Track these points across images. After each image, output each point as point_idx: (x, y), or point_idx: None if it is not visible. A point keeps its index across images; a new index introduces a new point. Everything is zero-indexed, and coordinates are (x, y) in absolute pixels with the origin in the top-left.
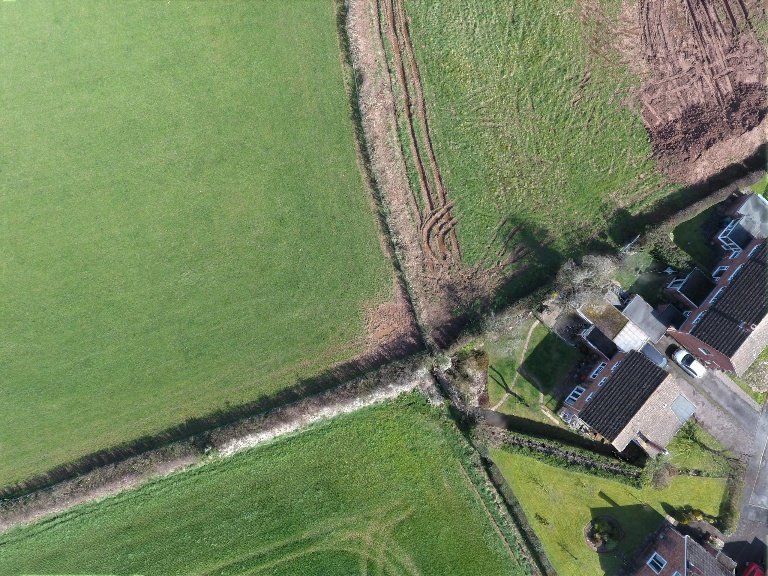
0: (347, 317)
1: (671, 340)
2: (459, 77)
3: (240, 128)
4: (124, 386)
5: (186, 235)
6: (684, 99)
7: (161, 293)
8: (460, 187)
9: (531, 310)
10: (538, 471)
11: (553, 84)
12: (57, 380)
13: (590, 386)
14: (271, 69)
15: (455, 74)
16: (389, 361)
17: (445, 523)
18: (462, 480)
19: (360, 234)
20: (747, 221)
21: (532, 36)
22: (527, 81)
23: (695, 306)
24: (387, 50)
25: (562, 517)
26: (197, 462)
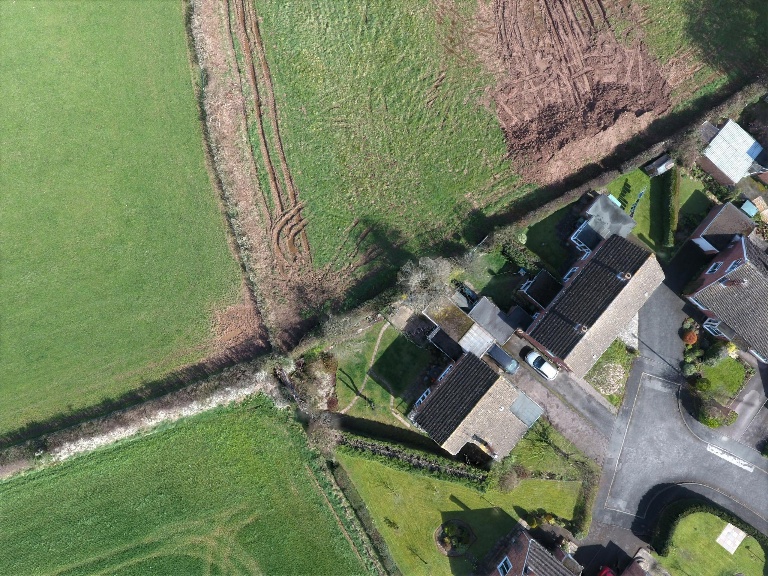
0: (193, 319)
1: (525, 342)
2: (311, 77)
3: (86, 129)
4: None
5: (29, 237)
6: (540, 99)
7: (3, 295)
8: (311, 188)
9: (379, 312)
10: (388, 474)
11: (407, 84)
12: None
13: (434, 389)
14: (118, 69)
15: (306, 74)
16: None
17: (292, 527)
18: (309, 484)
19: (207, 236)
20: (596, 222)
21: (385, 35)
22: (380, 81)
23: (542, 308)
24: (237, 50)
25: (412, 521)
26: (35, 466)
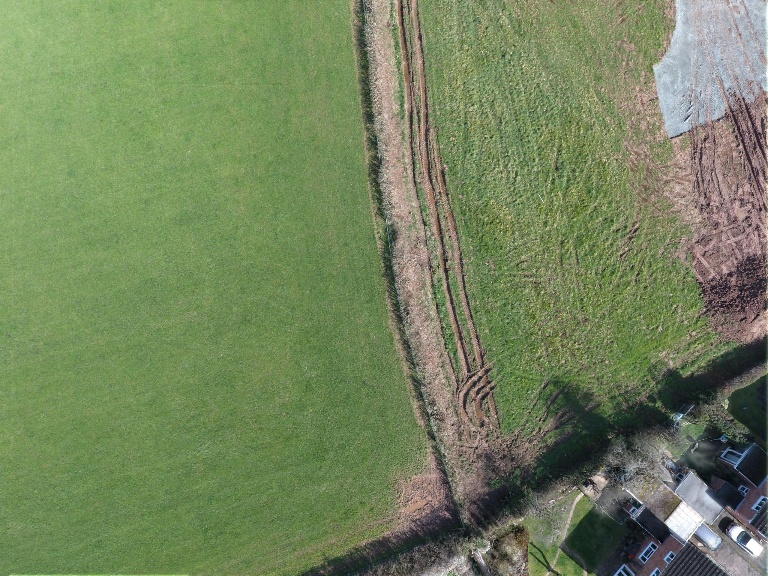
0: (378, 491)
1: (725, 513)
2: (499, 229)
3: (264, 286)
4: (139, 569)
5: (206, 403)
6: (739, 251)
7: (179, 467)
8: (499, 347)
9: (575, 485)
10: None
11: (599, 236)
12: (67, 564)
13: (640, 573)
14: (298, 222)
15: (494, 226)
16: (422, 538)
17: None
18: None
19: (392, 400)
20: None
21: (577, 184)
22: (571, 233)
23: (753, 484)
24: (422, 201)
25: None
26: None
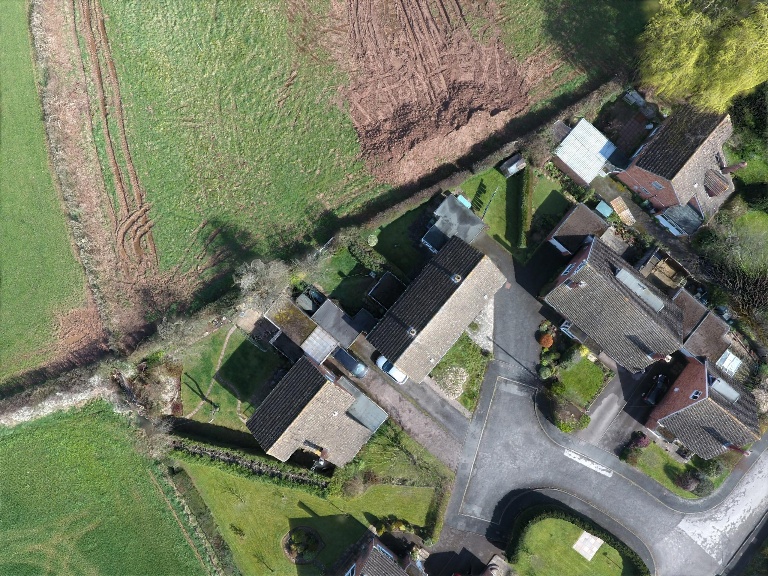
0: (34, 323)
1: None
2: (158, 76)
3: None
4: None
5: None
6: (395, 98)
7: None
8: (158, 189)
9: (223, 315)
10: (234, 481)
11: (257, 83)
12: None
13: None
14: None
15: (153, 73)
16: None
17: (133, 535)
18: (152, 490)
19: (49, 238)
20: (443, 223)
21: (235, 34)
22: (230, 80)
23: (387, 310)
24: (82, 48)
25: (259, 528)
26: None
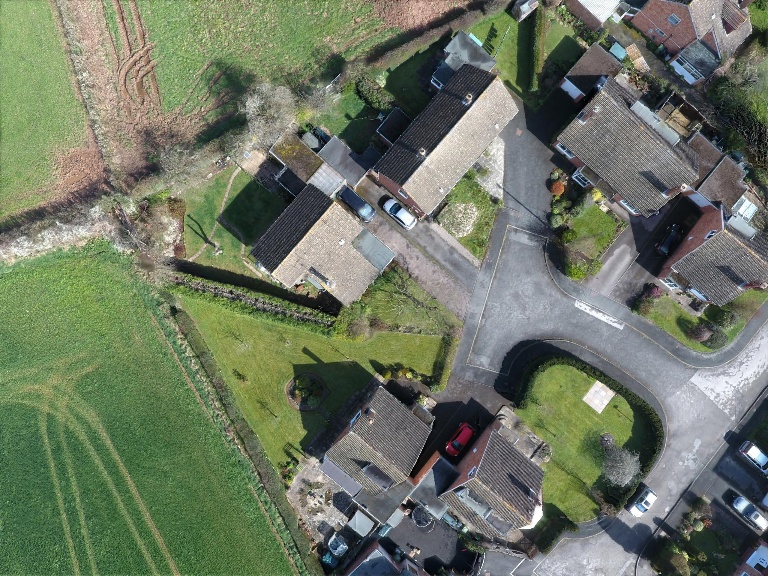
0: (34, 161)
1: (384, 191)
2: None
3: None
4: None
5: None
6: None
7: None
8: (161, 29)
9: (227, 154)
10: (238, 325)
11: None
12: None
13: None
14: None
15: None
16: None
17: (135, 377)
18: (154, 332)
19: (50, 75)
20: (453, 59)
21: None
22: None
23: None
24: None
25: (262, 373)
26: None
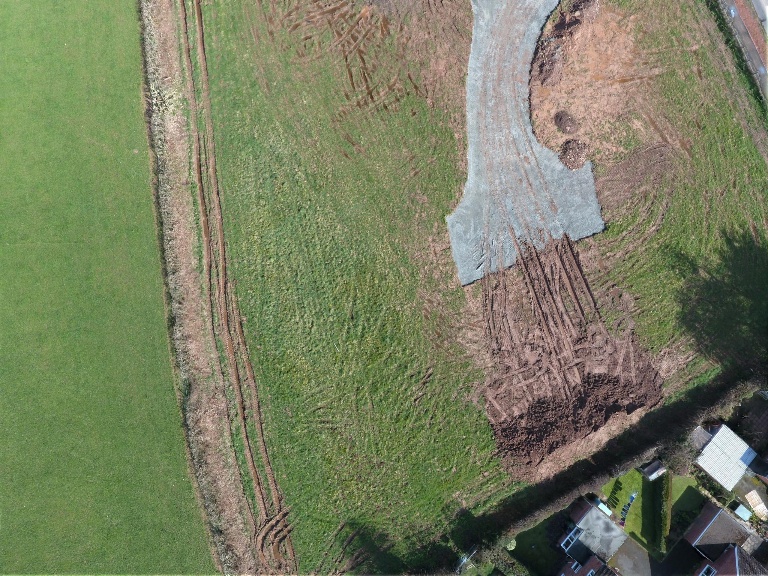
0: None
1: None
2: (295, 378)
3: (66, 438)
4: None
5: (9, 553)
6: (530, 393)
7: None
8: (296, 492)
9: None
10: None
11: (393, 382)
12: None
13: None
14: (99, 376)
15: (291, 375)
16: None
17: None
18: None
19: (190, 547)
20: (586, 536)
21: (372, 332)
22: (366, 379)
23: None
24: (220, 352)
25: None
26: None
